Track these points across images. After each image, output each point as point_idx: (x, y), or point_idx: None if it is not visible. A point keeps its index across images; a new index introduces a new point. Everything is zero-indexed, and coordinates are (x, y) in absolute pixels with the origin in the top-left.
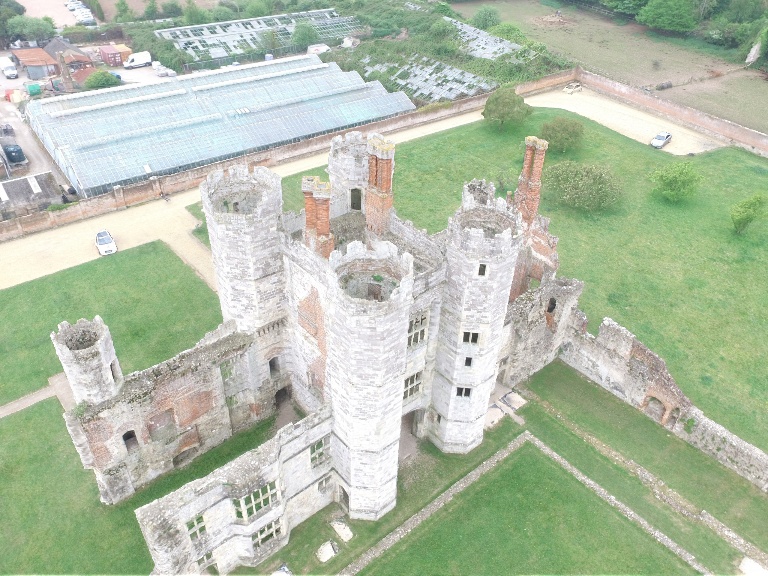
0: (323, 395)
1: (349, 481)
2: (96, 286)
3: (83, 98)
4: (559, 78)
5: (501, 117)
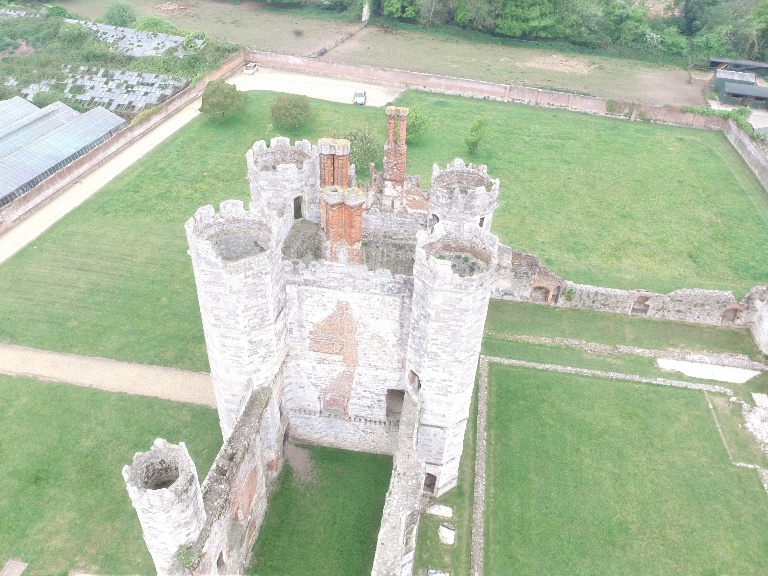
0: (347, 410)
1: (440, 461)
2: None
3: None
4: (233, 62)
5: (225, 109)
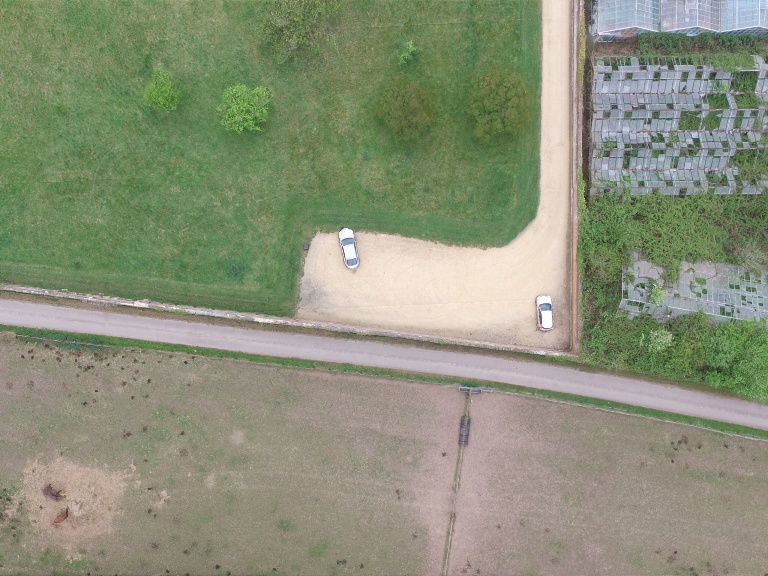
0: None
1: None
2: None
3: None
4: None
5: None
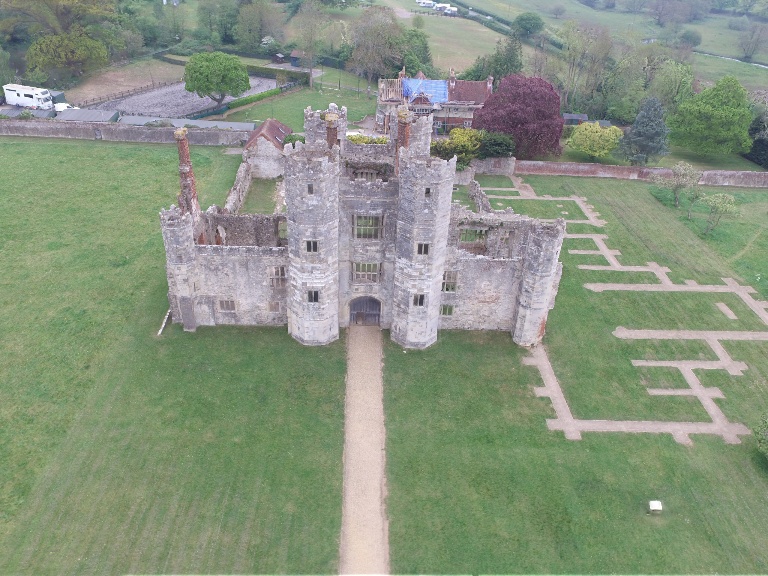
0: None
1: None
2: (519, 544)
3: None
4: None
5: None
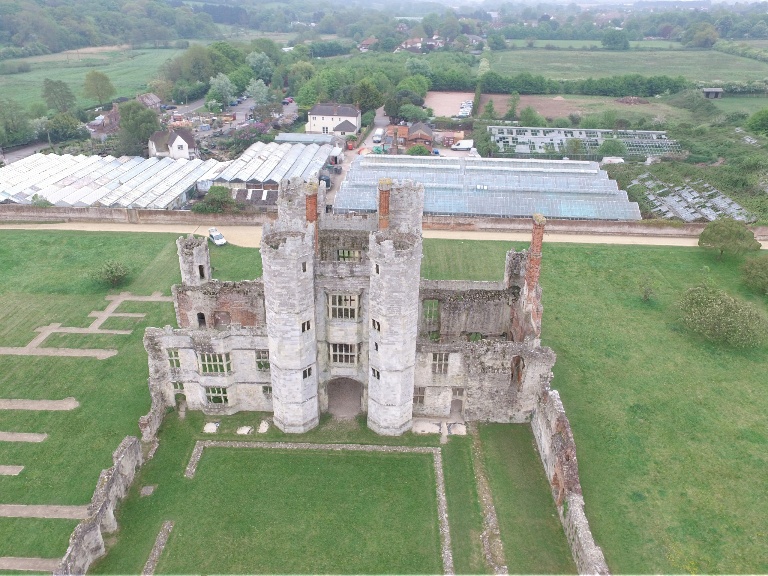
0: None
1: None
2: None
3: (392, 159)
4: None
5: (713, 244)
